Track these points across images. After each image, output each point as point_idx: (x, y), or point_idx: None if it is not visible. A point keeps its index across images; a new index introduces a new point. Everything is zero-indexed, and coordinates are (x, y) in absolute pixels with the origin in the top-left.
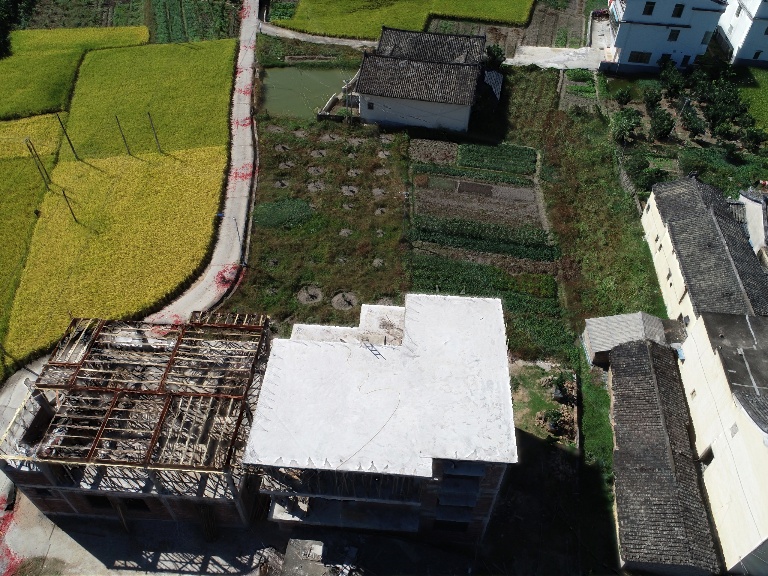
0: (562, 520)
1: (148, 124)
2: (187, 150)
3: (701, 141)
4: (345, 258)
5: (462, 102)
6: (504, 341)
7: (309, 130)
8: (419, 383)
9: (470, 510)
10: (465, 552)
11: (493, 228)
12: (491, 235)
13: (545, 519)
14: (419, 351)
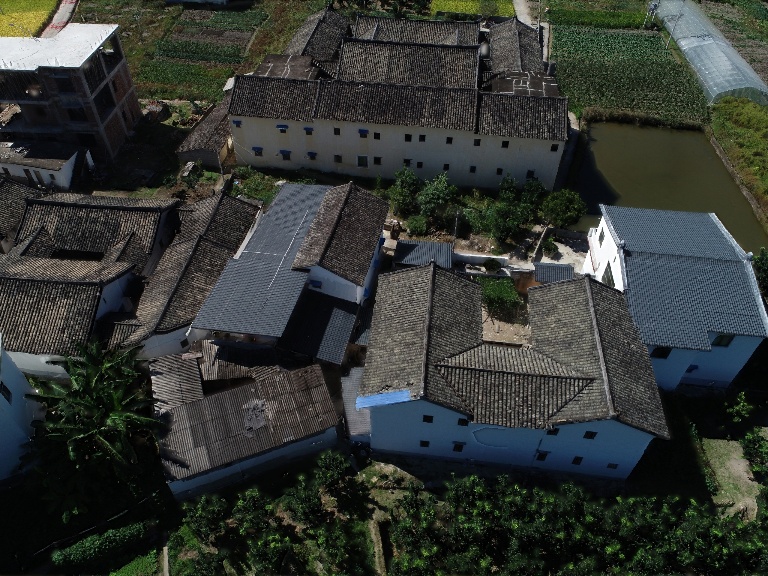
0: (163, 152)
1: (0, 1)
2: (22, 13)
3: (390, 9)
4: None
5: None
6: (107, 36)
7: (115, 5)
8: (51, 47)
9: (88, 121)
10: (103, 162)
11: (205, 46)
12: (204, 51)
13: (155, 152)
14: (59, 39)
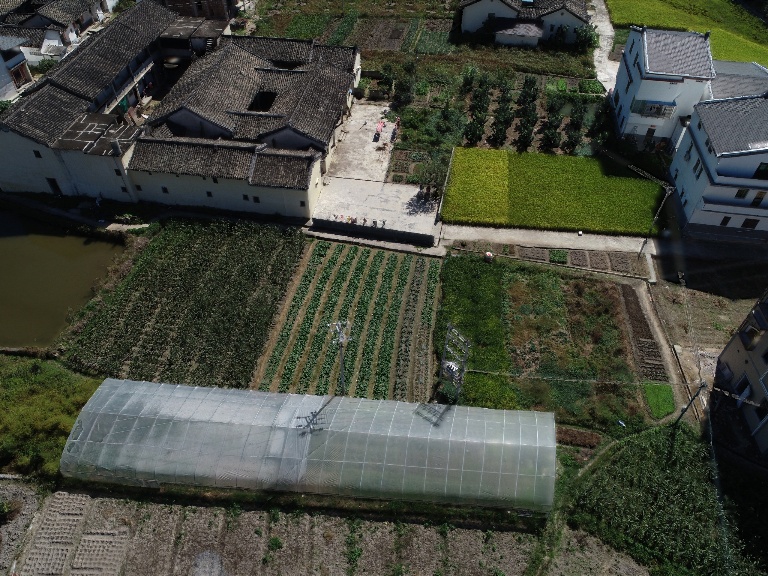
0: None
1: None
2: None
3: None
4: (331, 3)
5: (461, 4)
6: None
7: None
8: None
9: None
10: None
11: None
12: None
13: None
14: None
